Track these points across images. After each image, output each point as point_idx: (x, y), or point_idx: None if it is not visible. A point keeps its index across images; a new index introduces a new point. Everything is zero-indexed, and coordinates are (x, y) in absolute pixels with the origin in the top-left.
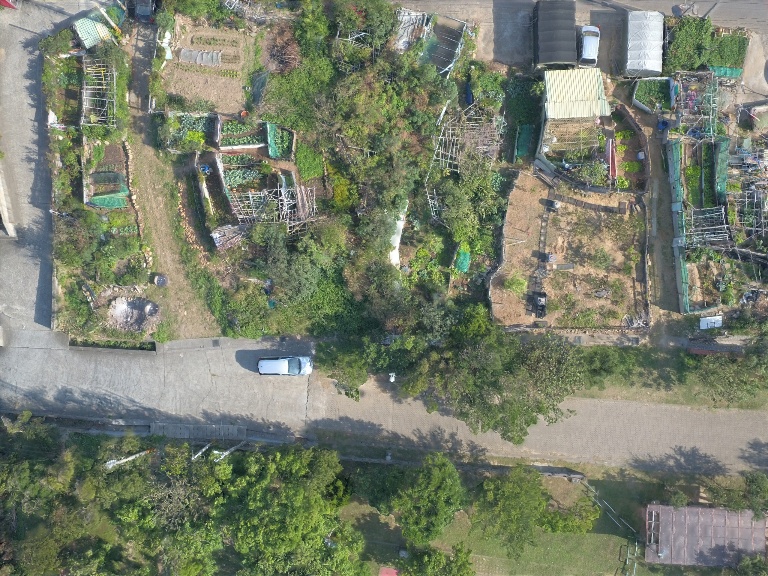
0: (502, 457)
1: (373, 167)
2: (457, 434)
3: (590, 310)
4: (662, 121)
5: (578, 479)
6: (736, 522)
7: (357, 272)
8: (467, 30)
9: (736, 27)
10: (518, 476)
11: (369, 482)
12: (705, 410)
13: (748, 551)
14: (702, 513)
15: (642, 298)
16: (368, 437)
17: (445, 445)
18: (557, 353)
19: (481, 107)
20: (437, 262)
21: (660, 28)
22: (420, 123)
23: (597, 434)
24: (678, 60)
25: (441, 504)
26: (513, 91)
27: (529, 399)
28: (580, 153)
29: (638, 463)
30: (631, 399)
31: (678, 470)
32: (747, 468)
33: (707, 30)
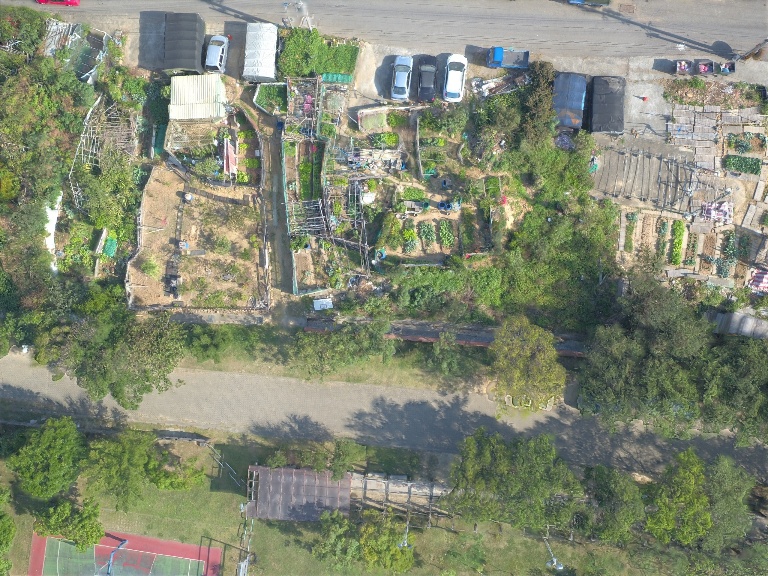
0: (141, 423)
1: (28, 161)
2: (103, 402)
3: (219, 292)
4: (277, 122)
5: (205, 443)
6: (325, 482)
7: (13, 255)
8: (114, 39)
9: (352, 38)
10: (128, 438)
11: (7, 442)
12: (317, 383)
13: (333, 508)
14: (296, 474)
15: (264, 282)
16: (27, 403)
17: (92, 411)
18: (158, 328)
19: (119, 108)
20: (88, 247)
21: (273, 38)
22: (68, 122)
23: (224, 403)
24: (288, 67)
25: (54, 461)
26: (153, 94)
27: (134, 369)
28: (206, 150)
29: (258, 430)
30: (254, 372)
31: (293, 436)
32: (353, 436)
33: (312, 41)
